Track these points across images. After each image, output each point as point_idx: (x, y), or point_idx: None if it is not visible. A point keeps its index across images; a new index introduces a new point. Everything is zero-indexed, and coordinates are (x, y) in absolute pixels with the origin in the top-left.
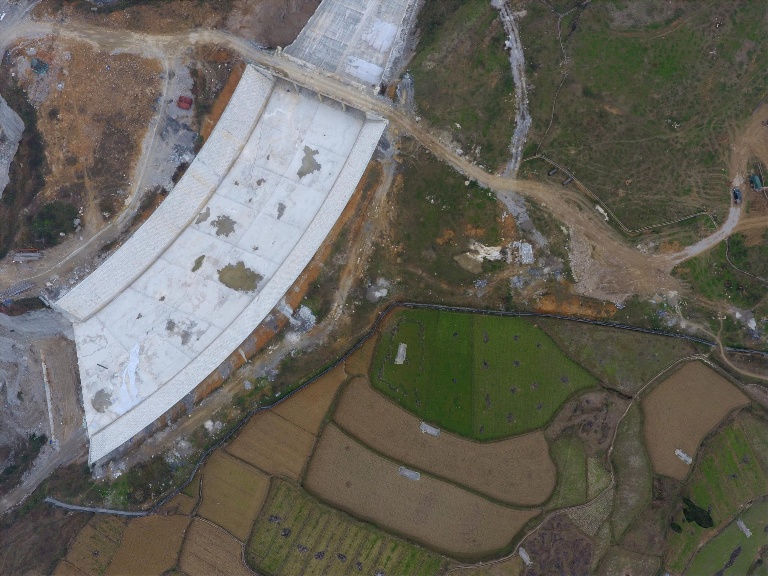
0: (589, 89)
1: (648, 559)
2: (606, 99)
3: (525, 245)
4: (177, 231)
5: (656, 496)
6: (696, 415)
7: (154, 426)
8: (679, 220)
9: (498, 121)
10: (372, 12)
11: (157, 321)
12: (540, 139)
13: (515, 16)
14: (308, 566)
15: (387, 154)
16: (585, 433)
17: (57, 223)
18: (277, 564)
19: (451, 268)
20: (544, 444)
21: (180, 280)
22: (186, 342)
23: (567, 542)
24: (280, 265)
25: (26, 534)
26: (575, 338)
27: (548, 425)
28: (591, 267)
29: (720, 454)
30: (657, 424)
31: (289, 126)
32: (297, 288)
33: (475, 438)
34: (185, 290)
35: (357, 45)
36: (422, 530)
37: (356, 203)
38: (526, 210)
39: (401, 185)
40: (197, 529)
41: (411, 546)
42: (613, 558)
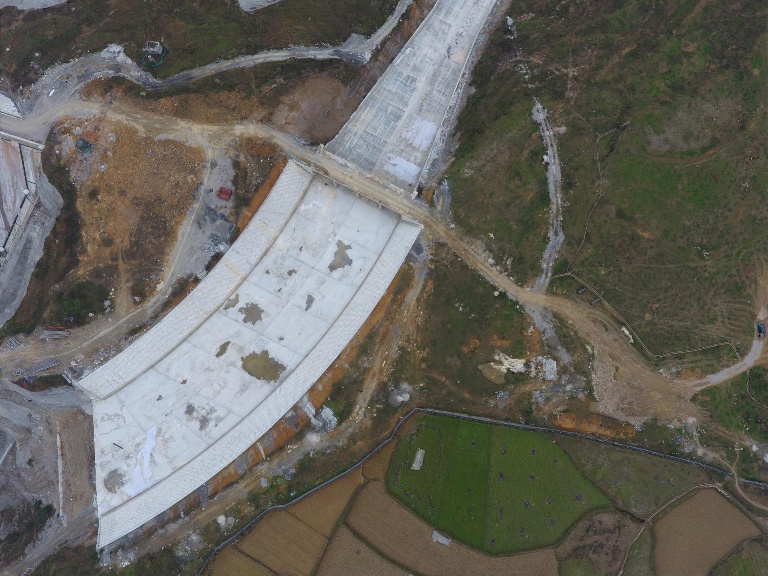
0: (622, 211)
1: None
2: (638, 222)
3: (550, 361)
4: (205, 316)
5: None
6: (707, 543)
7: (166, 515)
8: (703, 348)
9: (531, 234)
10: (413, 110)
11: (177, 404)
12: (571, 256)
13: (555, 132)
14: None
15: (420, 259)
16: (596, 555)
17: (87, 303)
18: None
19: (474, 377)
20: (554, 562)
21: (203, 364)
22: (204, 427)
23: None
24: (304, 357)
25: None
26: (592, 457)
27: (560, 543)
28: (613, 388)
29: None
30: (668, 549)
31: (324, 219)
32: (320, 386)
33: (486, 551)
34: (207, 375)
35: (397, 142)
36: None
37: (386, 306)
38: (553, 326)
39: (431, 291)
40: None
41: None
42: None
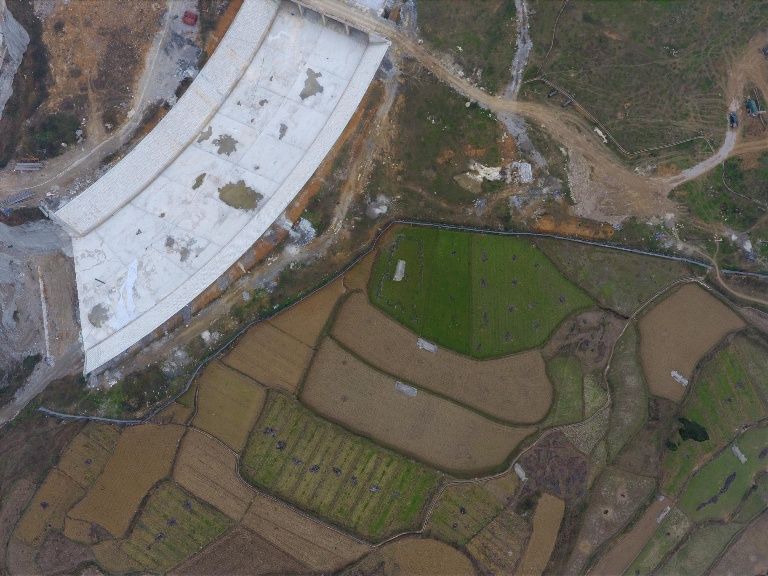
0: (589, 15)
1: (643, 479)
2: (606, 25)
3: (524, 165)
4: (179, 148)
5: (652, 416)
6: (692, 337)
7: (151, 337)
8: (676, 143)
9: (499, 45)
10: None
11: (156, 237)
12: (540, 62)
13: None
14: (303, 479)
15: (389, 74)
16: (582, 352)
17: (59, 134)
18: (271, 477)
19: (451, 187)
20: (541, 363)
21: (180, 197)
22: (185, 259)
23: (563, 459)
24: (281, 184)
25: (18, 444)
26: (573, 258)
27: (545, 344)
28: (589, 188)
29: (716, 378)
30: (653, 345)
31: (293, 49)
32: (297, 203)
33: (472, 356)
34: (185, 207)
35: None
36: (418, 446)
37: (358, 120)
38: (526, 131)
39: (403, 105)
40: (191, 440)
41: (407, 461)
42: (608, 478)
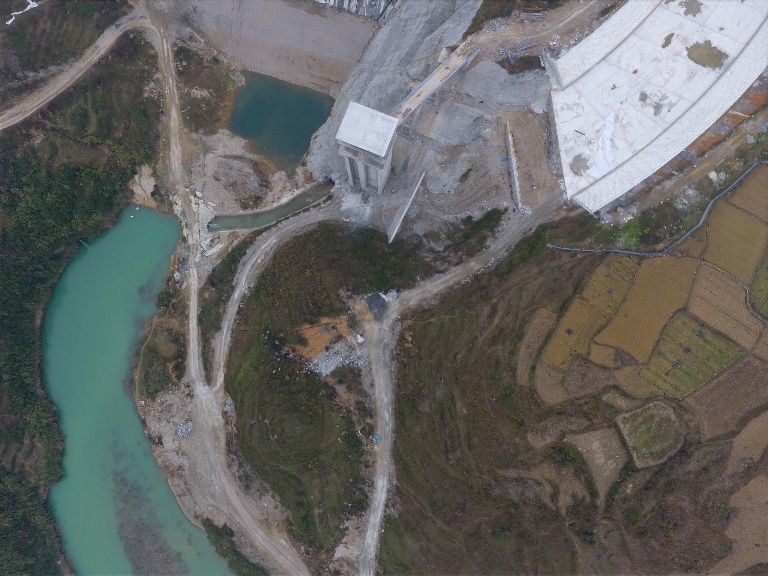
0: None
1: None
2: None
3: None
4: (652, 7)
5: None
6: None
7: (653, 179)
8: None
9: None
10: None
11: (630, 92)
12: None
13: None
14: None
15: None
16: None
17: None
18: None
19: None
20: None
21: (651, 55)
22: (658, 113)
23: None
24: (745, 45)
25: (530, 277)
26: None
27: None
28: None
29: None
30: None
31: None
32: None
33: None
34: (656, 65)
35: None
36: None
37: None
38: None
39: None
40: (703, 273)
41: None
42: None
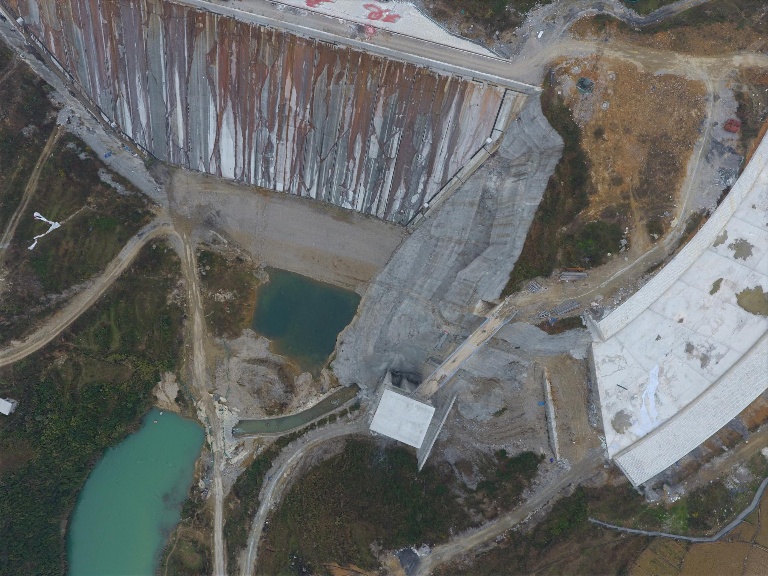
0: None
1: None
2: None
3: None
4: (700, 253)
5: None
6: None
7: (701, 450)
8: None
9: None
10: None
11: (676, 343)
12: None
13: None
14: None
15: None
16: None
17: (602, 243)
18: None
19: None
20: None
21: (698, 302)
22: (705, 365)
23: None
24: None
25: (571, 555)
26: None
27: None
28: None
29: None
30: None
31: None
32: None
33: None
34: (703, 313)
35: None
36: None
37: None
38: None
39: None
40: (754, 557)
41: None
42: None
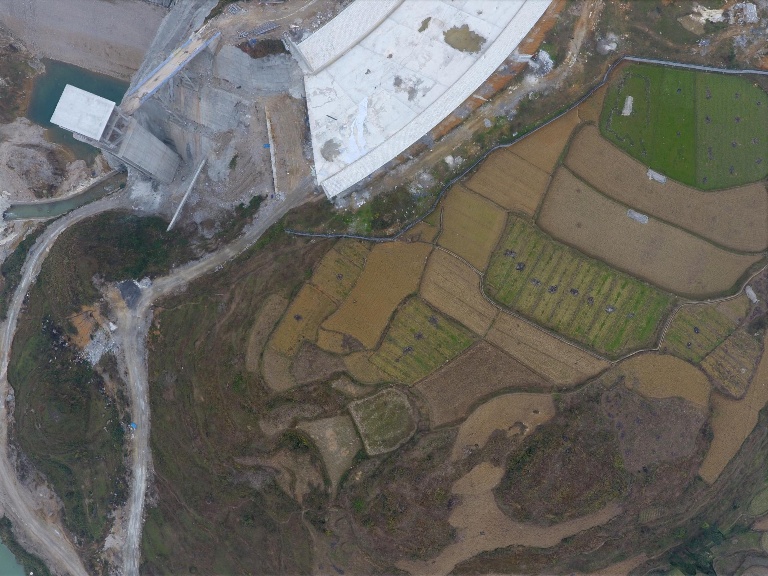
0: None
1: None
2: None
3: (750, 5)
4: None
5: None
6: None
7: (393, 163)
8: None
9: None
10: None
11: (385, 77)
12: None
13: None
14: (542, 299)
15: None
16: None
17: None
18: (512, 296)
19: (675, 28)
20: (765, 195)
21: (407, 39)
22: (412, 98)
23: None
24: (503, 29)
25: (266, 263)
26: None
27: None
28: None
29: None
30: None
31: None
32: (530, 40)
33: (699, 187)
34: (412, 49)
35: None
36: (650, 271)
37: None
38: None
39: None
40: (437, 258)
41: (641, 284)
42: None
